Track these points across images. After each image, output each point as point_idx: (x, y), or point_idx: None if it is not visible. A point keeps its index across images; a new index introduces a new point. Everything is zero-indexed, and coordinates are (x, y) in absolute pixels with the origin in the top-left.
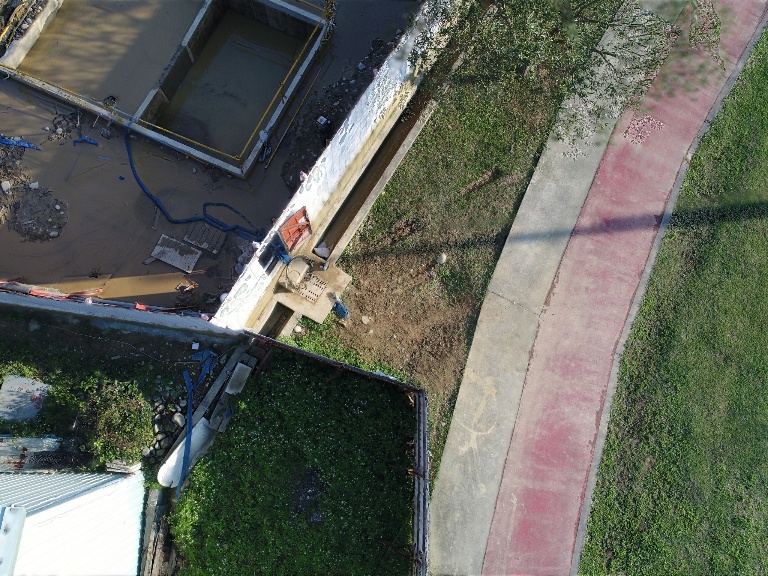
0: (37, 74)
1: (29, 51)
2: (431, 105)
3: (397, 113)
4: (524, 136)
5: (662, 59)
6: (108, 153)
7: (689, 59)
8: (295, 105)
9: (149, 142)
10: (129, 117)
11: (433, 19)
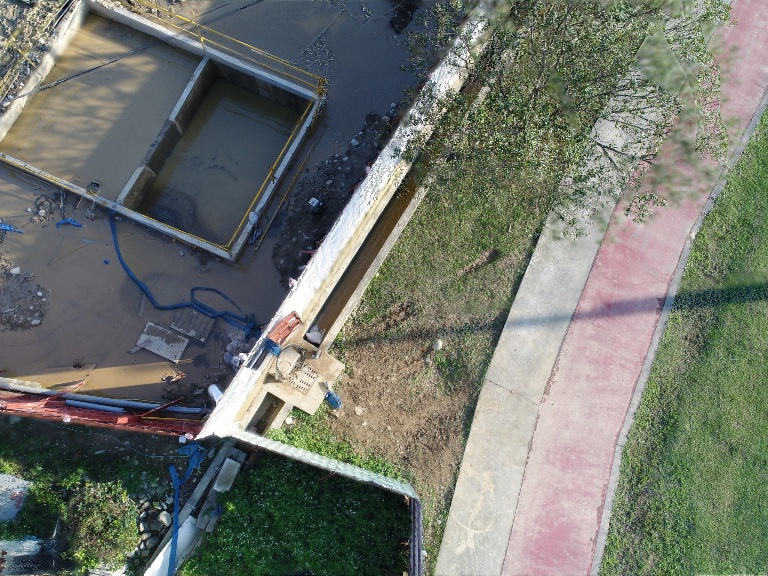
0: (19, 153)
1: (11, 128)
2: (427, 182)
3: (392, 191)
4: (523, 215)
5: (665, 133)
6: (93, 232)
7: (692, 133)
8: (286, 183)
9: (135, 224)
10: (114, 198)
11: (428, 110)
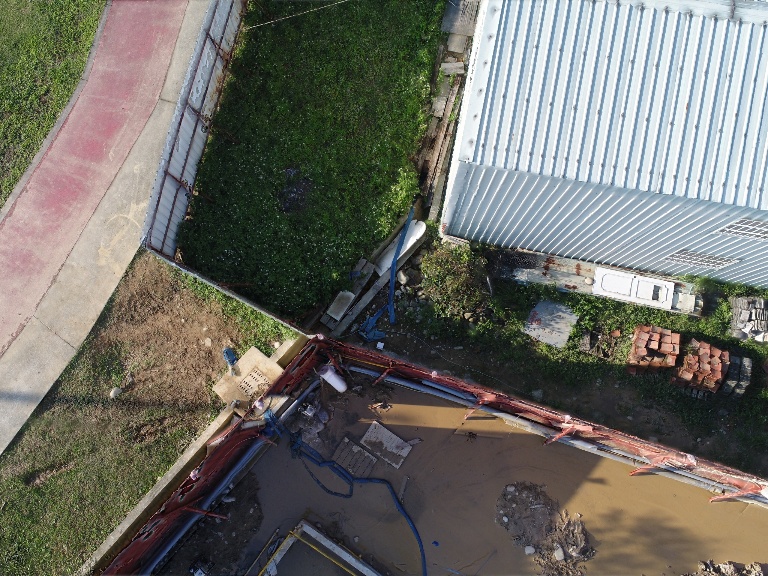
0: None
1: None
2: None
3: None
4: None
5: None
6: None
7: None
8: None
9: None
10: None
11: None
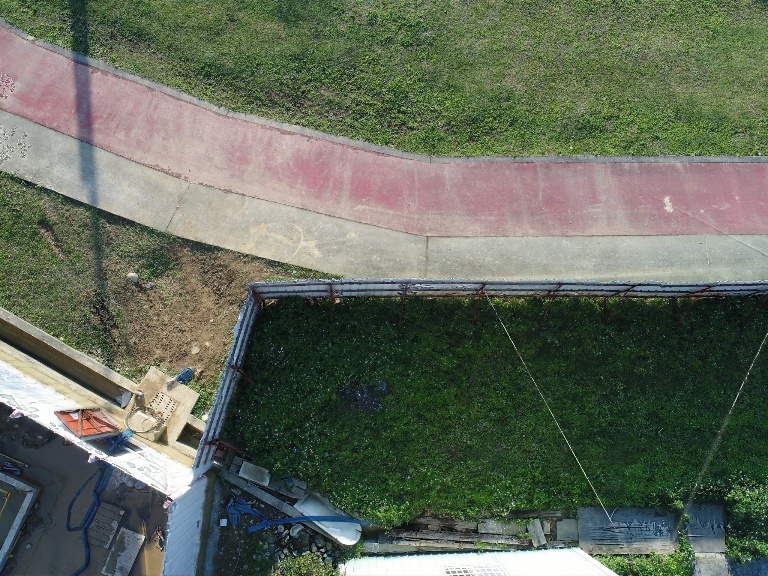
0: None
1: None
2: None
3: None
4: (2, 196)
5: None
6: None
7: None
8: None
9: None
10: None
11: None
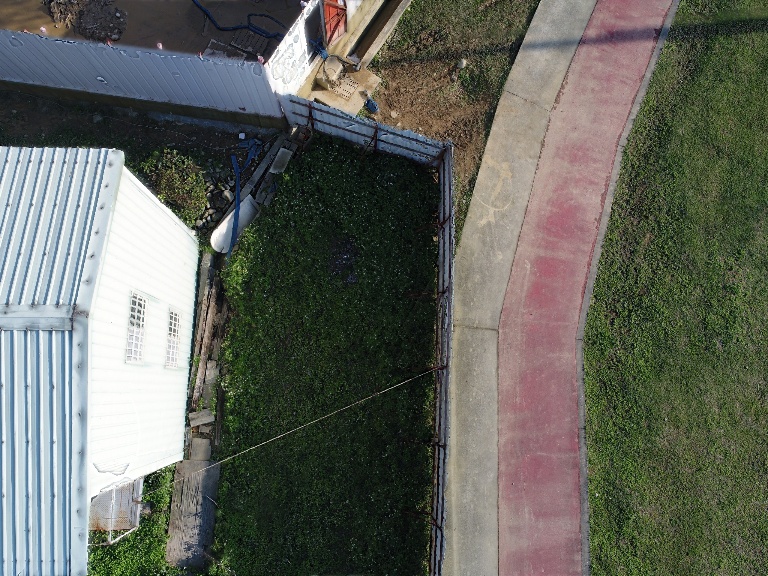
0: None
1: None
2: None
3: None
4: None
5: None
6: None
7: None
8: None
9: None
10: None
11: None
